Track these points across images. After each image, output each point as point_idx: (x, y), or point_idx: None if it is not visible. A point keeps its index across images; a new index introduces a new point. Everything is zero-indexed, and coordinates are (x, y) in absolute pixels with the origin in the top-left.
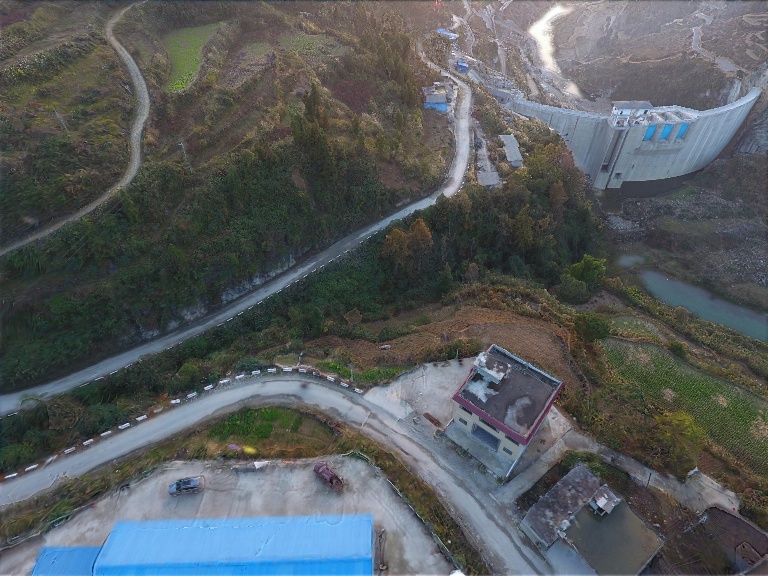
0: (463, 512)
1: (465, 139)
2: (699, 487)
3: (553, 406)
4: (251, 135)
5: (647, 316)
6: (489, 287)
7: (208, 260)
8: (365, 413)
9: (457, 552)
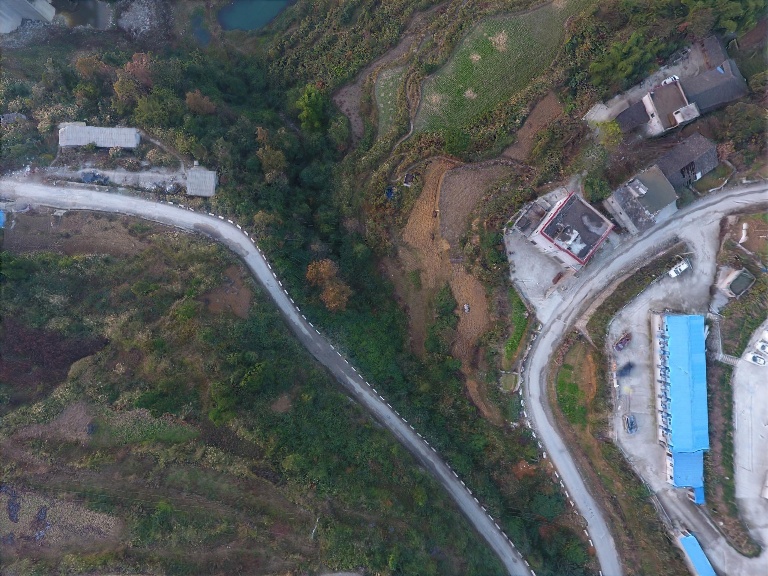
0: (624, 265)
1: (86, 196)
2: (594, 122)
3: (547, 195)
4: (244, 469)
5: (367, 70)
6: (373, 212)
7: (406, 471)
8: (557, 322)
9: (660, 272)
